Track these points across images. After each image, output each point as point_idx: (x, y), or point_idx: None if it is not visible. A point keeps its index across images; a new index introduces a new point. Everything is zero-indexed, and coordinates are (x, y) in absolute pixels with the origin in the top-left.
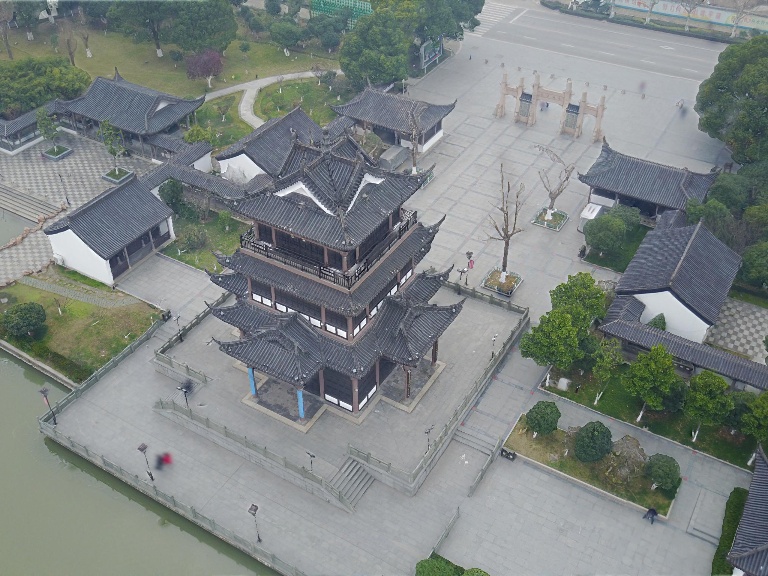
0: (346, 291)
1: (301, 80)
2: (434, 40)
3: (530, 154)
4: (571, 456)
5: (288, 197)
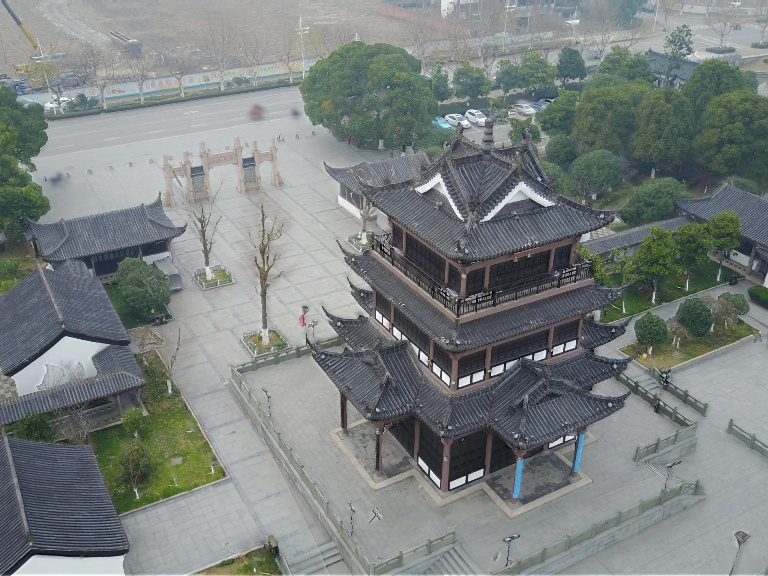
0: (590, 282)
1: None
2: (27, 163)
3: (255, 215)
4: (681, 346)
5: (494, 217)
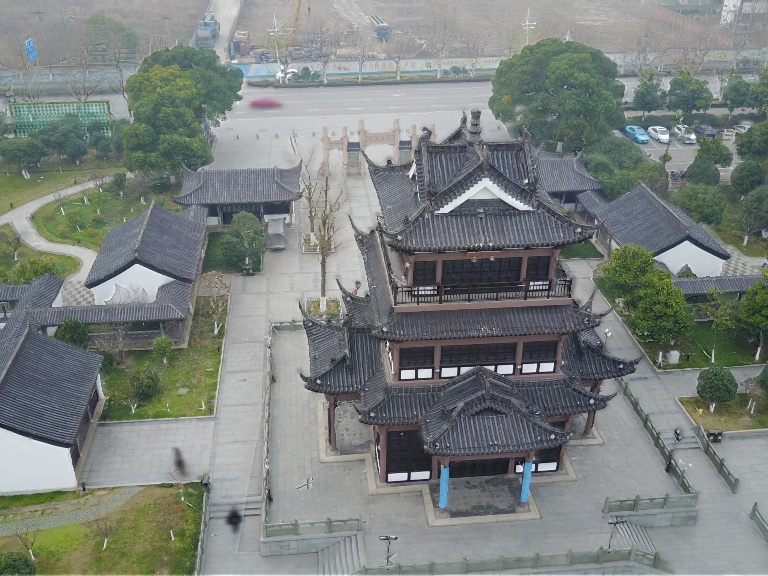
0: (567, 301)
1: (82, 192)
2: (213, 119)
3: None
4: (757, 412)
5: (455, 211)
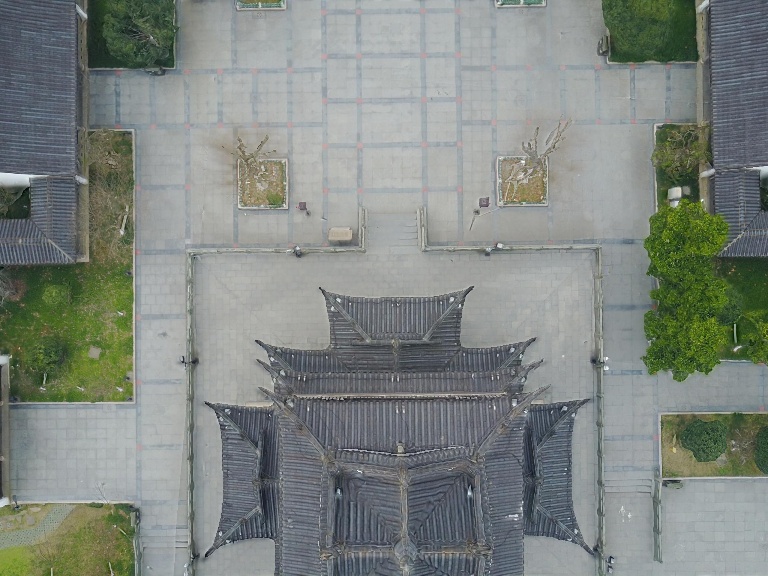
0: None
1: None
2: None
3: None
4: None
5: None
